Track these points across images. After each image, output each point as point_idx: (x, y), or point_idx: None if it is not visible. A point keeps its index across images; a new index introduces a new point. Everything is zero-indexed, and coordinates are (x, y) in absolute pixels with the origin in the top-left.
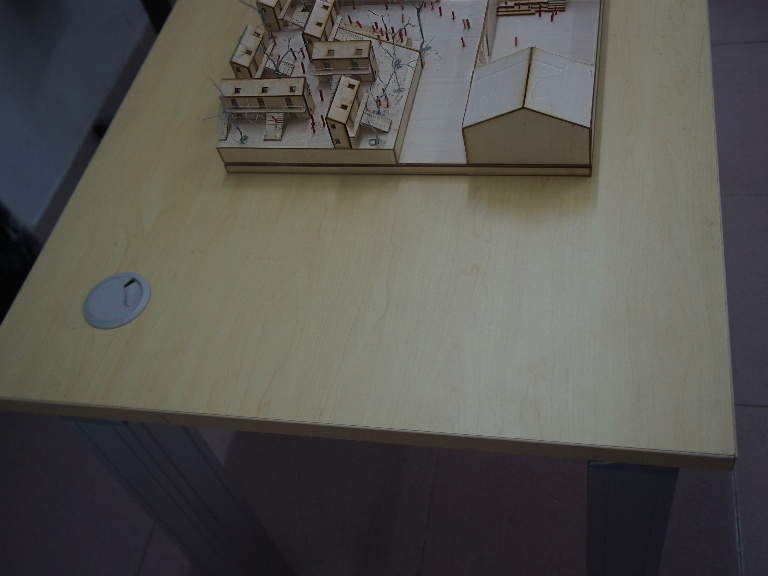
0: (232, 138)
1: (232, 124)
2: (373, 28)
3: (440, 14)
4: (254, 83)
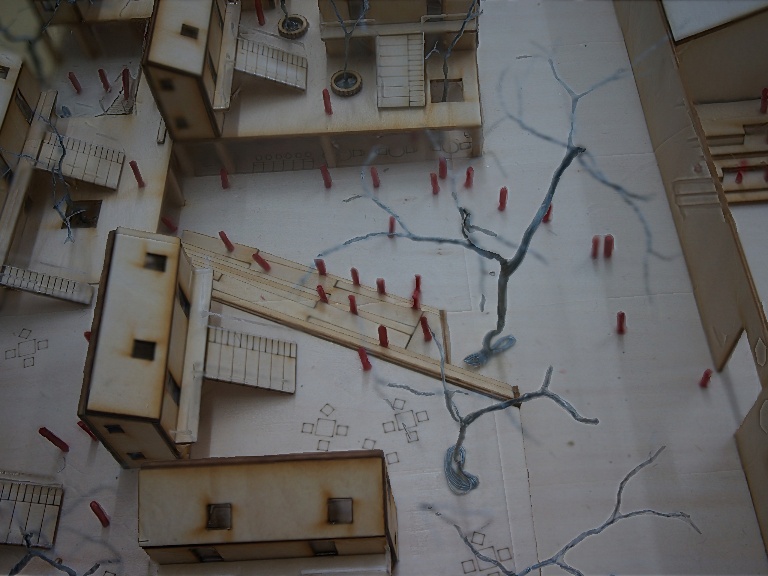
0: None
1: None
2: (320, 292)
3: (500, 205)
4: None
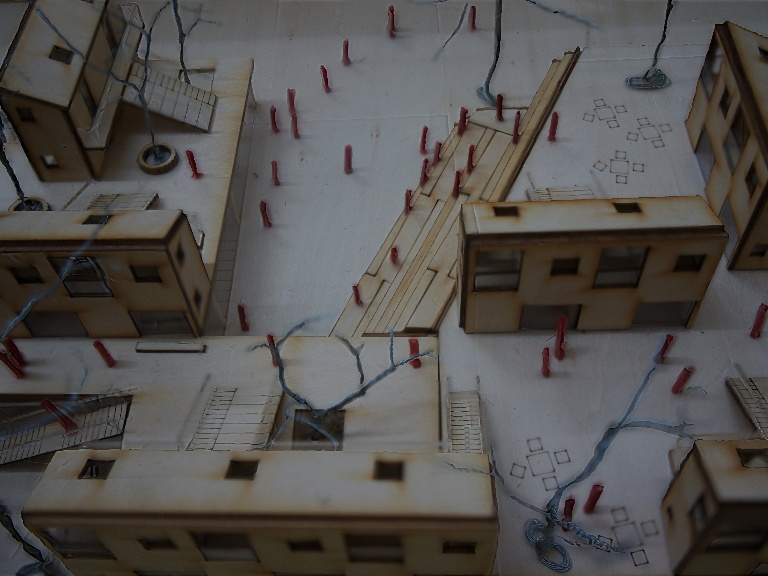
0: None
1: None
2: (458, 180)
3: (327, 88)
4: None
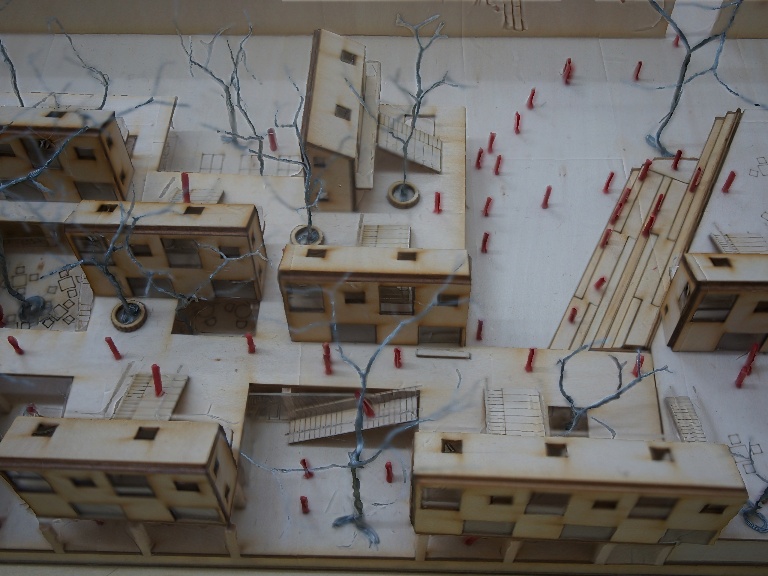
0: None
1: None
2: (651, 223)
3: (517, 130)
4: None
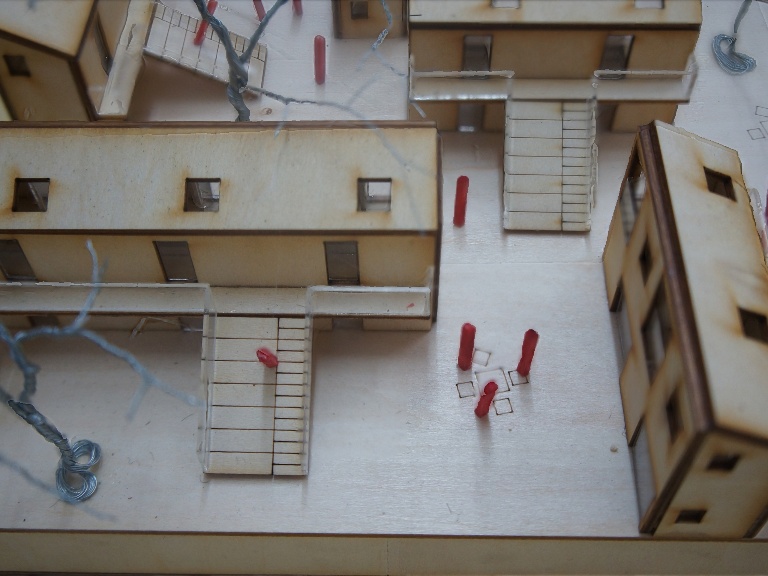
0: (6, 459)
1: (1, 371)
2: None
3: None
4: (131, 152)
